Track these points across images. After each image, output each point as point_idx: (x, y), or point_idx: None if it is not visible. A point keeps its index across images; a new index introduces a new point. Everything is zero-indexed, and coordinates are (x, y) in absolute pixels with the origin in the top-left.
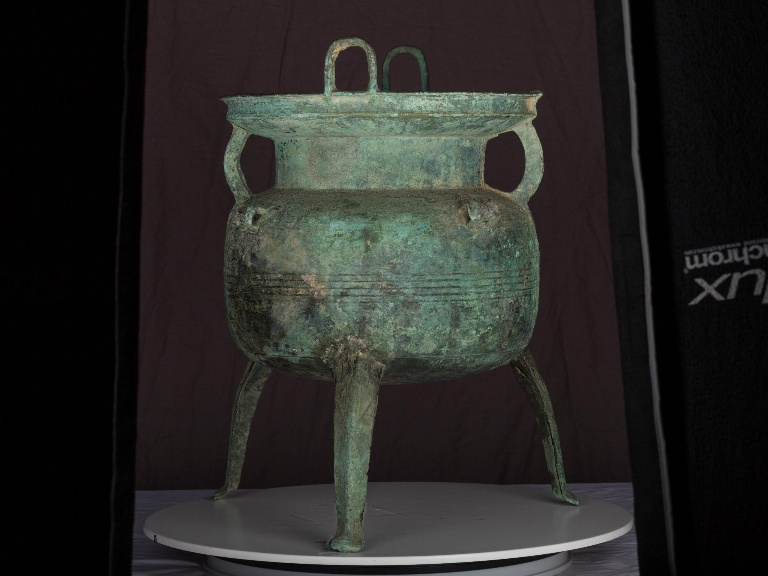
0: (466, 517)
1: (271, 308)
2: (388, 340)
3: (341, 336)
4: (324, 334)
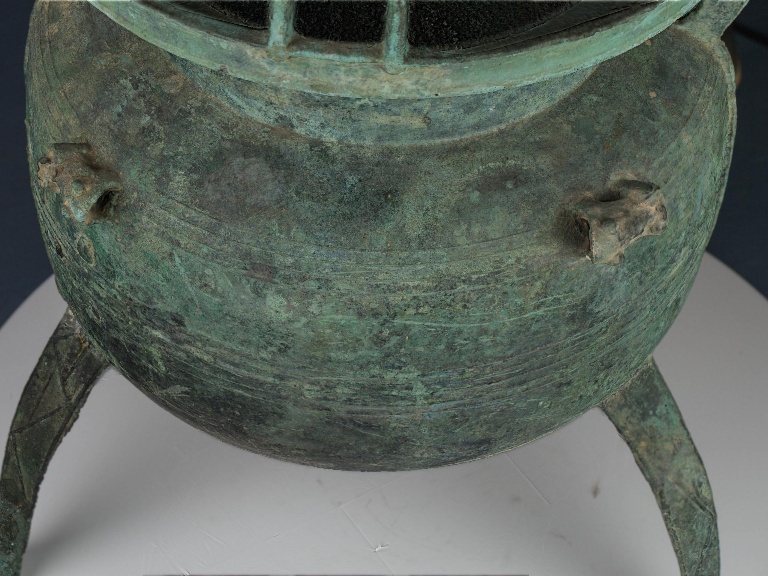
0: (203, 460)
1: (570, 5)
2: (340, 7)
3: (428, 3)
4: (460, 6)
